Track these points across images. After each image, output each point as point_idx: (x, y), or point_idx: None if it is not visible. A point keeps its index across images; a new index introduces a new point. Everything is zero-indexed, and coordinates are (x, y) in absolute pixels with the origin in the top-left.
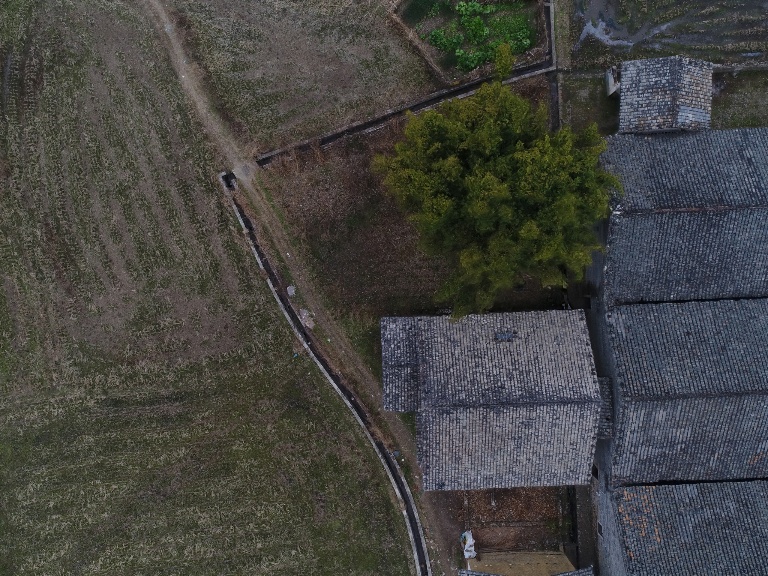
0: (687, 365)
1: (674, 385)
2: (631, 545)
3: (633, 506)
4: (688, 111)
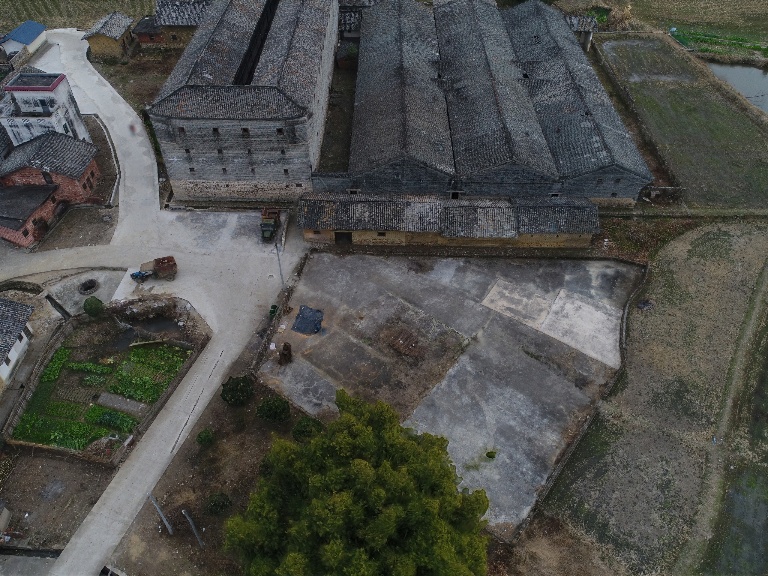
0: None
1: (475, 4)
2: (416, 2)
3: None
4: (577, 21)
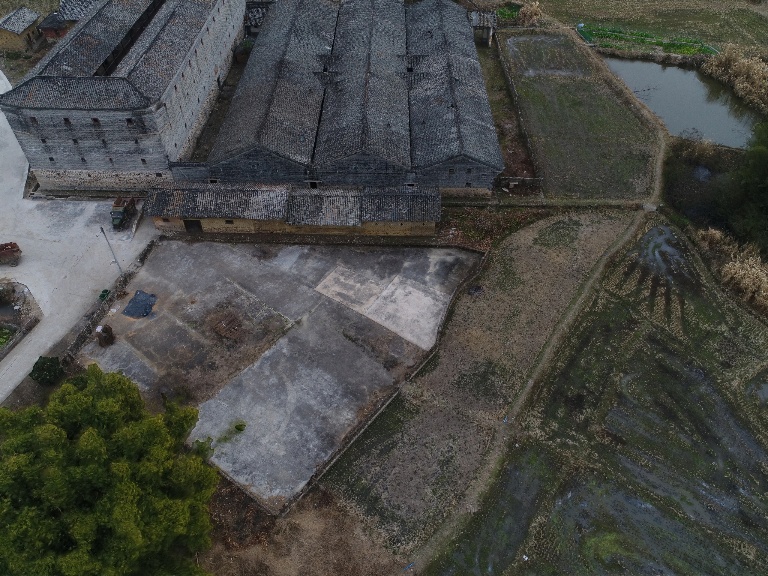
0: (383, 5)
1: None
2: None
3: (333, 5)
4: (476, 16)
